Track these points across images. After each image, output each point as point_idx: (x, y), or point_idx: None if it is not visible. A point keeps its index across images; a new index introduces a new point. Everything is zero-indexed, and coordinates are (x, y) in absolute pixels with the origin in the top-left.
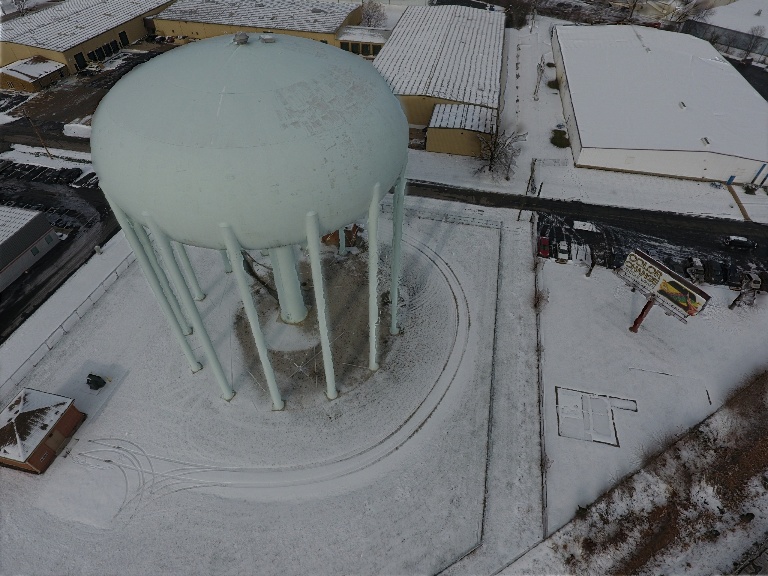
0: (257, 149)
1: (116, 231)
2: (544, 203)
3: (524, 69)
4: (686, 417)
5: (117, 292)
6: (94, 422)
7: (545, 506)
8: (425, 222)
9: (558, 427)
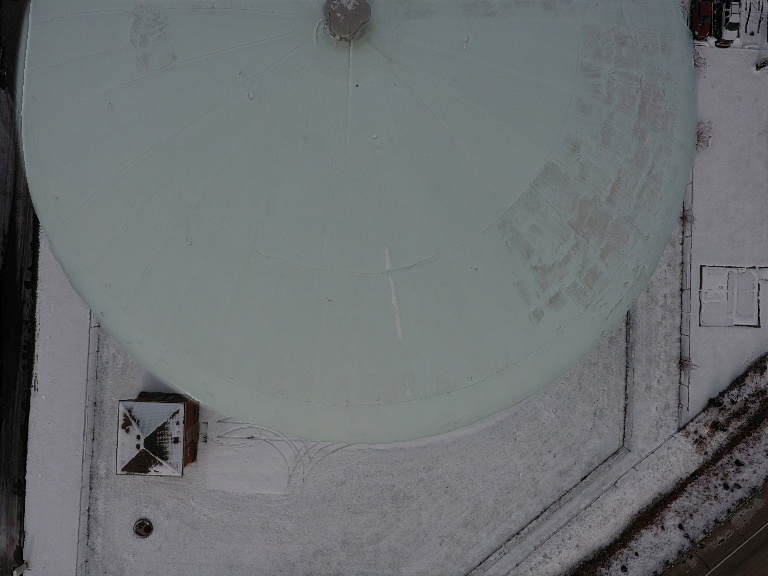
0: (494, 378)
1: None
2: None
3: None
4: None
5: None
6: None
7: (681, 401)
8: None
9: (700, 317)
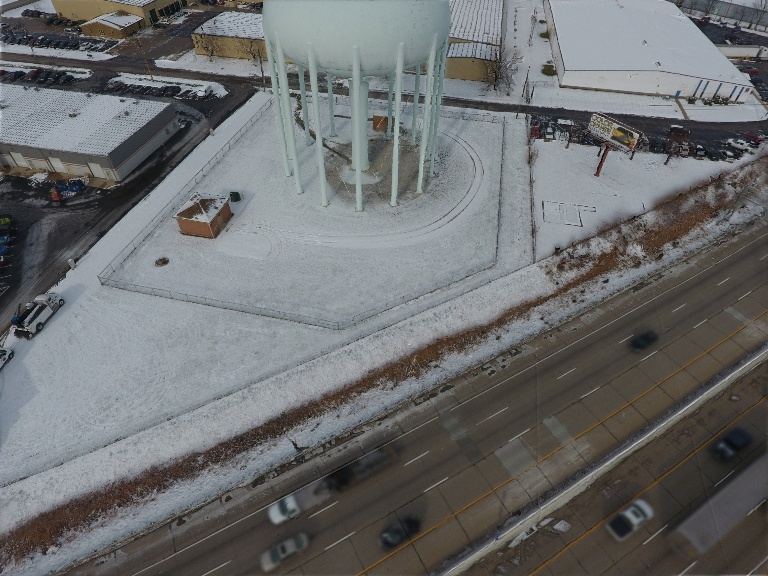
0: (376, 2)
1: (219, 123)
2: (536, 109)
3: (520, 25)
4: (627, 215)
5: (232, 156)
6: (240, 216)
7: (535, 250)
8: (447, 119)
9: (543, 218)
